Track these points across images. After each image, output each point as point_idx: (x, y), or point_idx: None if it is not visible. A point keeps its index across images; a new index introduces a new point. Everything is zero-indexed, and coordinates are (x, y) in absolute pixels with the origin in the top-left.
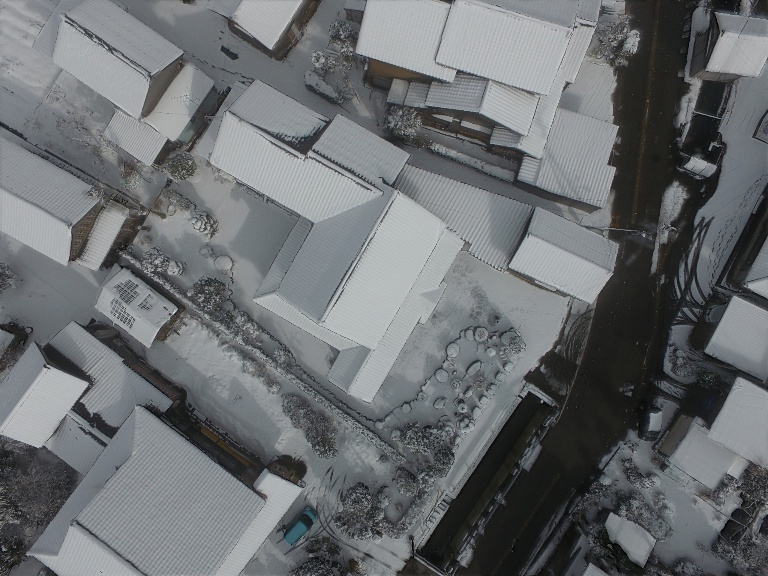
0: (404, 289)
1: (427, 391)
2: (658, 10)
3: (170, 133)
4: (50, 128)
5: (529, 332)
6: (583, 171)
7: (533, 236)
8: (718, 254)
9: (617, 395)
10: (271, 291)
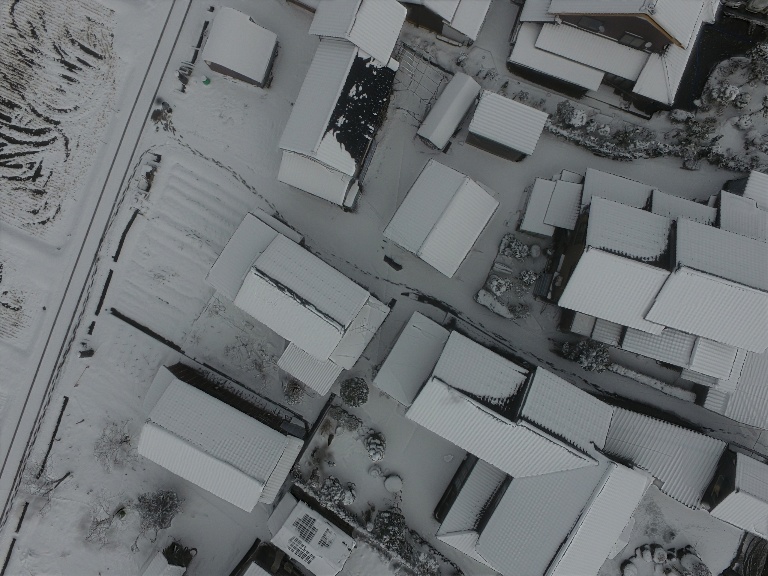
0: (609, 547)
1: None
2: None
3: (346, 364)
4: (209, 342)
5: (706, 549)
6: None
7: (742, 492)
8: None
9: None
10: (457, 530)
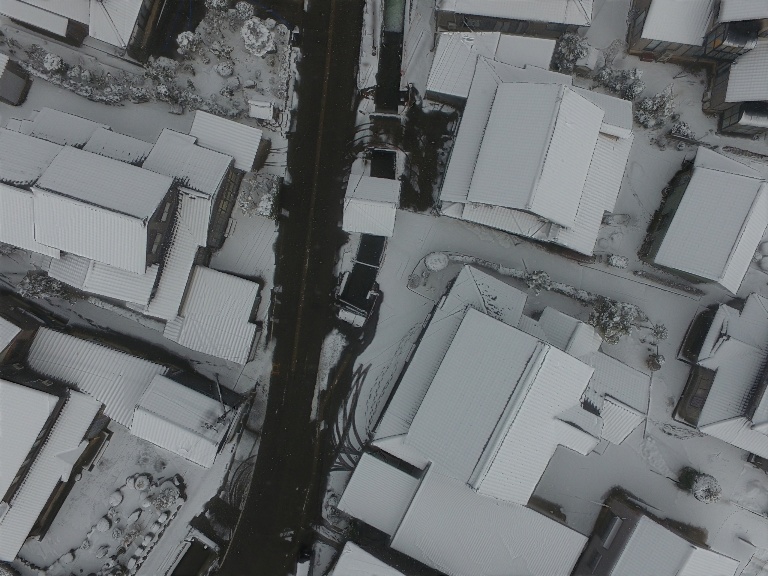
0: (15, 462)
1: (91, 539)
2: (318, 161)
3: None
4: None
5: (194, 478)
6: (224, 329)
7: (140, 409)
8: (375, 400)
9: (278, 540)
10: None
